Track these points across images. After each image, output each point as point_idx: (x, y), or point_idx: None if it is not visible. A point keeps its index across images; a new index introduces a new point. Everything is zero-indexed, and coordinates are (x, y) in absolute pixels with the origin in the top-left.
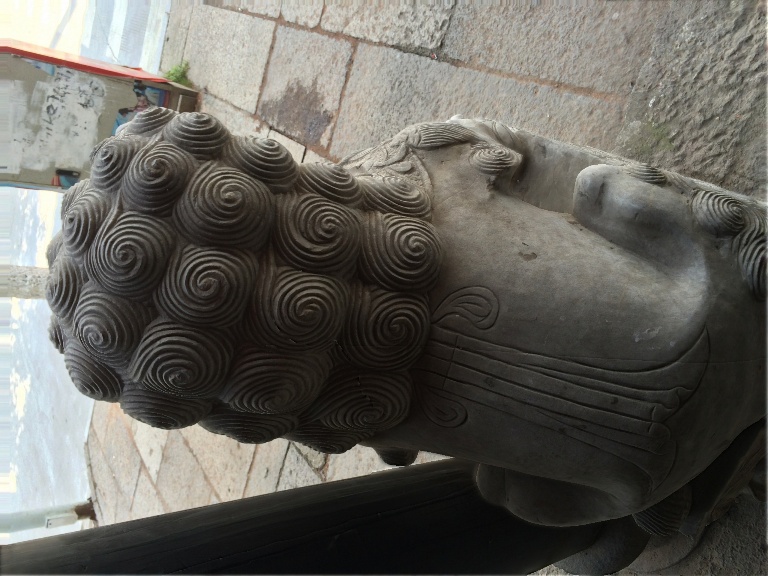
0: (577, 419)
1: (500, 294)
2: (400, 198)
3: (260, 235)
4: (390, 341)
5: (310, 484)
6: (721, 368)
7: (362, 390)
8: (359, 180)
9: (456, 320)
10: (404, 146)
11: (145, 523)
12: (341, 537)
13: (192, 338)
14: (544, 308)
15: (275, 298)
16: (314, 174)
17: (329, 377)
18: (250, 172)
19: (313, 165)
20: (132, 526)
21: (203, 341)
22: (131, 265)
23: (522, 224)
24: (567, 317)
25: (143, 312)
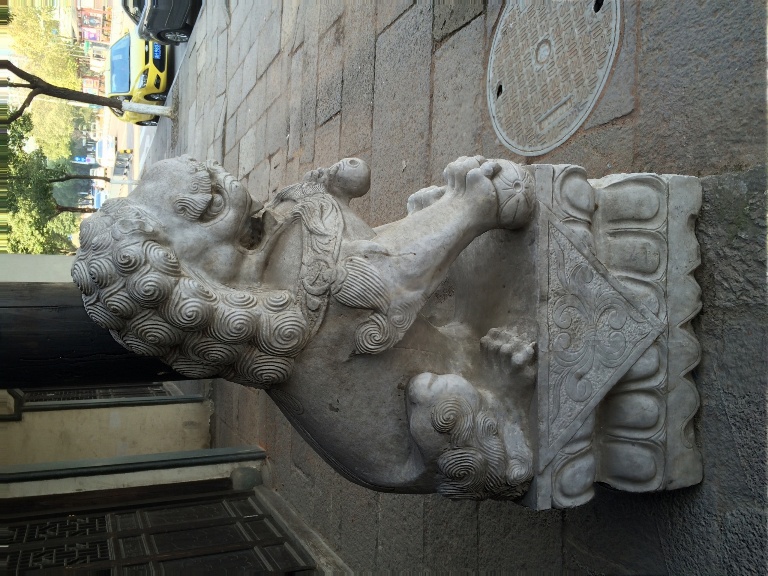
0: None
1: (305, 411)
2: (276, 347)
3: None
4: None
5: None
6: None
7: None
8: (260, 321)
9: None
10: (325, 288)
11: None
12: None
13: None
14: (321, 431)
15: (173, 366)
16: (217, 330)
17: None
18: None
19: (221, 321)
20: None
21: None
22: None
23: (351, 386)
24: (329, 442)
25: None
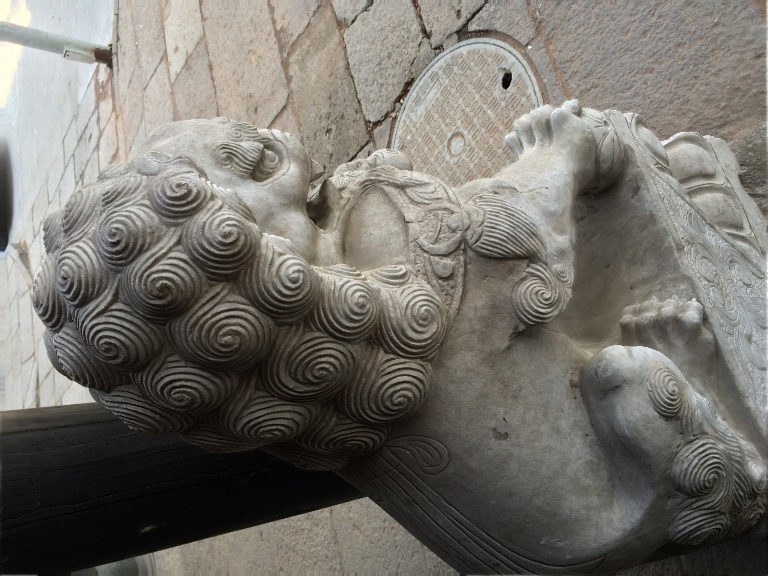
0: (461, 555)
1: (454, 458)
2: (411, 339)
3: (248, 364)
4: (339, 449)
5: None
6: (598, 575)
7: (301, 460)
8: (382, 299)
9: (405, 455)
10: (458, 239)
11: (95, 435)
12: (256, 474)
13: (156, 413)
14: (483, 487)
15: (242, 418)
16: (330, 311)
17: (276, 442)
18: (260, 307)
19: (335, 295)
20: (83, 438)
21: (166, 417)
22: (112, 357)
23: (518, 391)
24: (497, 503)
25: (117, 377)
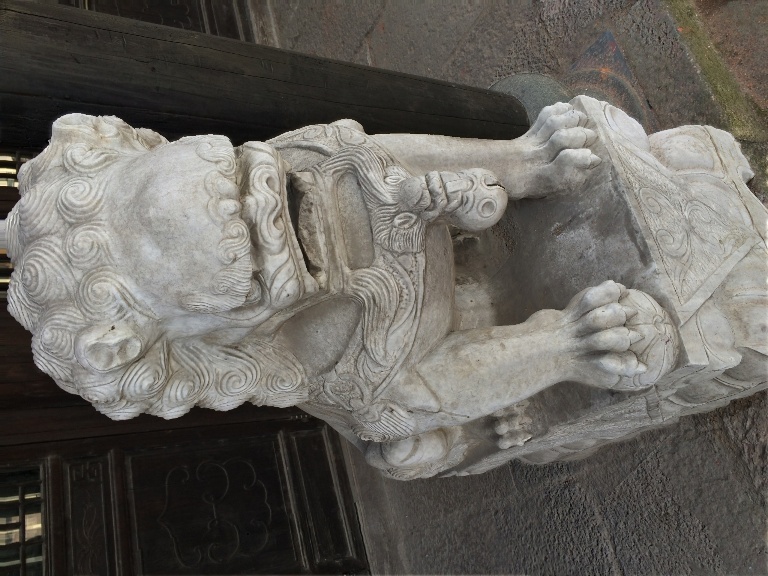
0: None
1: None
2: None
3: None
4: None
5: (264, 122)
6: None
7: None
8: (255, 397)
9: None
10: None
11: None
12: None
13: None
14: None
15: None
16: None
17: None
18: None
19: None
20: None
21: None
22: None
23: None
24: None
25: None
